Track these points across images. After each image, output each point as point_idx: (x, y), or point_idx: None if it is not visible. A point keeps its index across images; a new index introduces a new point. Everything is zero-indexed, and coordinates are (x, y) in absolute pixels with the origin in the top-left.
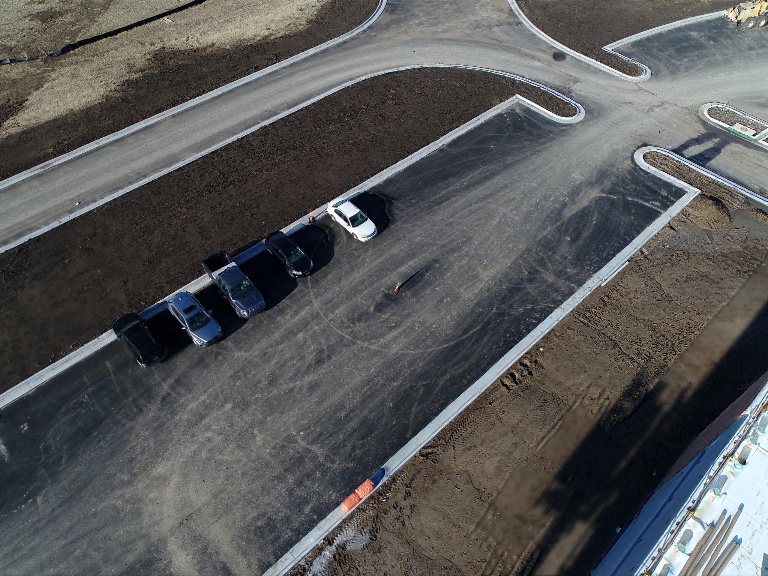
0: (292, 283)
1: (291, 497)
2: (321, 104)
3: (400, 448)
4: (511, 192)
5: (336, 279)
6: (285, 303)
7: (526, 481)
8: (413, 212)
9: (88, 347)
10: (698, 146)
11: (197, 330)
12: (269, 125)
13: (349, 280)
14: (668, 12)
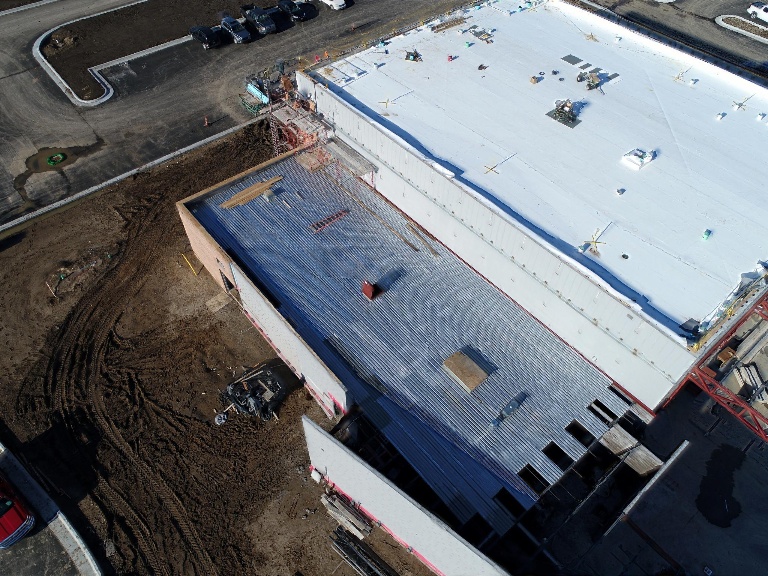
0: (292, 24)
1: None
2: None
3: None
4: None
5: (318, 24)
6: (287, 31)
7: None
8: (370, 0)
9: (176, 41)
10: None
11: (237, 33)
12: None
13: (326, 25)
14: None
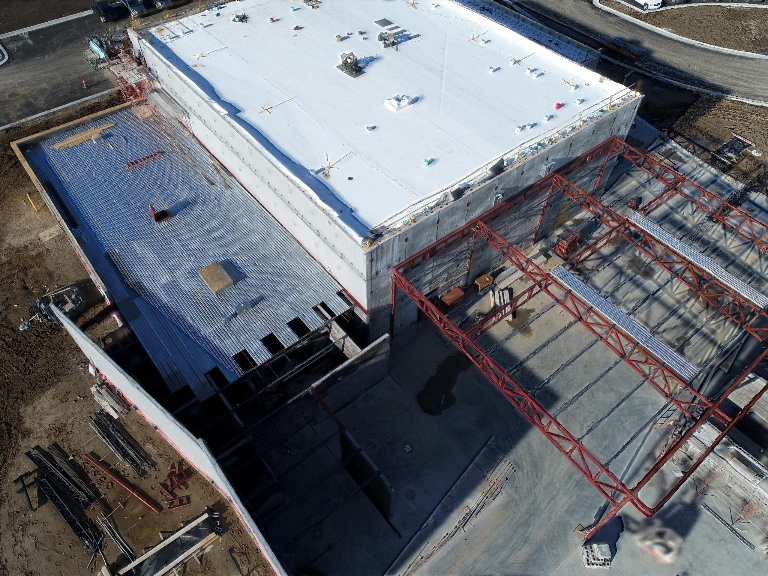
0: (191, 1)
1: None
2: None
3: None
4: None
5: None
6: (184, 7)
7: None
8: None
9: (77, 15)
10: None
11: (133, 7)
12: None
13: None
14: None
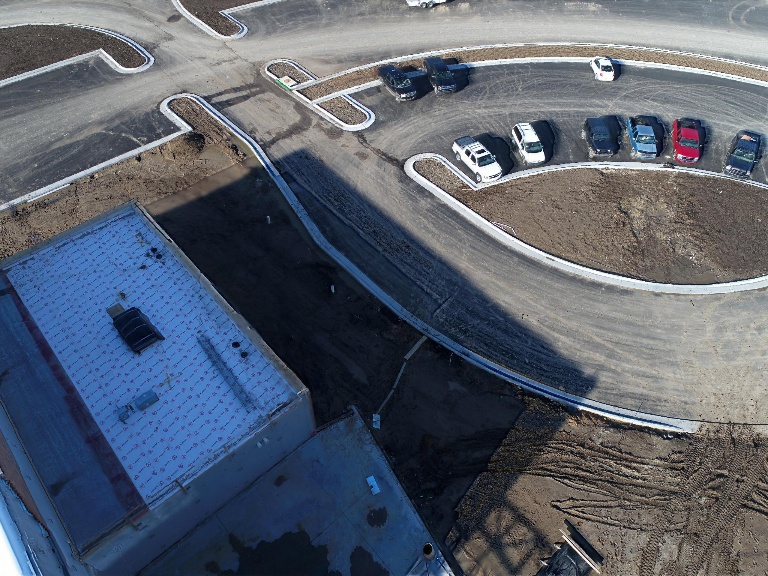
0: None
1: None
2: None
3: None
4: (20, 128)
5: None
6: None
7: None
8: None
9: None
10: (232, 94)
11: None
12: None
13: None
14: None
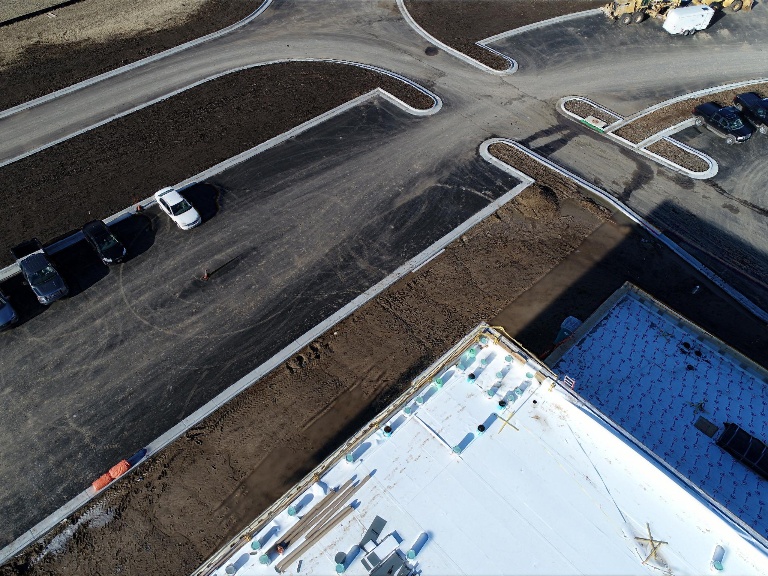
0: (104, 270)
1: (47, 478)
2: (180, 97)
3: (168, 429)
4: (348, 182)
5: (149, 266)
6: (92, 290)
7: (283, 460)
8: (244, 201)
9: None
10: (546, 138)
11: None
12: (123, 117)
13: (162, 267)
14: (549, 8)
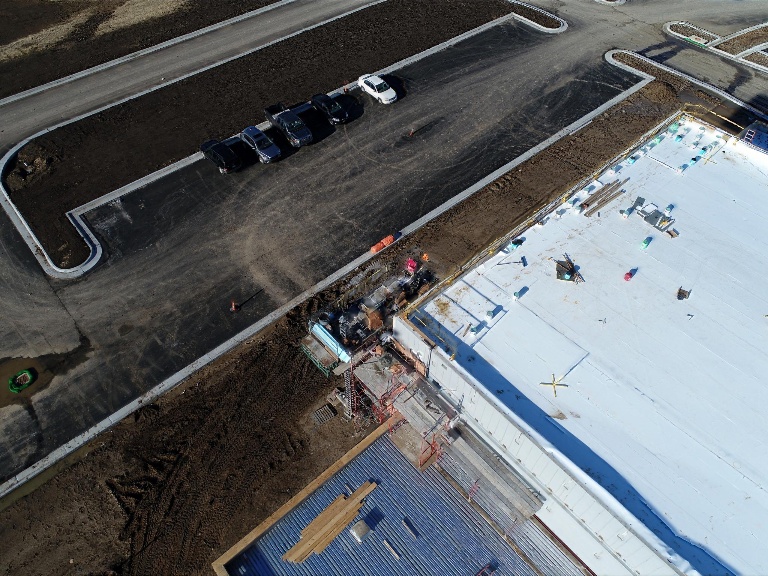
0: (332, 129)
1: (335, 246)
2: (352, 17)
3: (413, 222)
4: (503, 77)
5: (365, 127)
6: (327, 140)
7: None
8: (425, 88)
9: (182, 162)
10: (658, 50)
11: (263, 150)
12: (310, 30)
13: (375, 128)
14: None
